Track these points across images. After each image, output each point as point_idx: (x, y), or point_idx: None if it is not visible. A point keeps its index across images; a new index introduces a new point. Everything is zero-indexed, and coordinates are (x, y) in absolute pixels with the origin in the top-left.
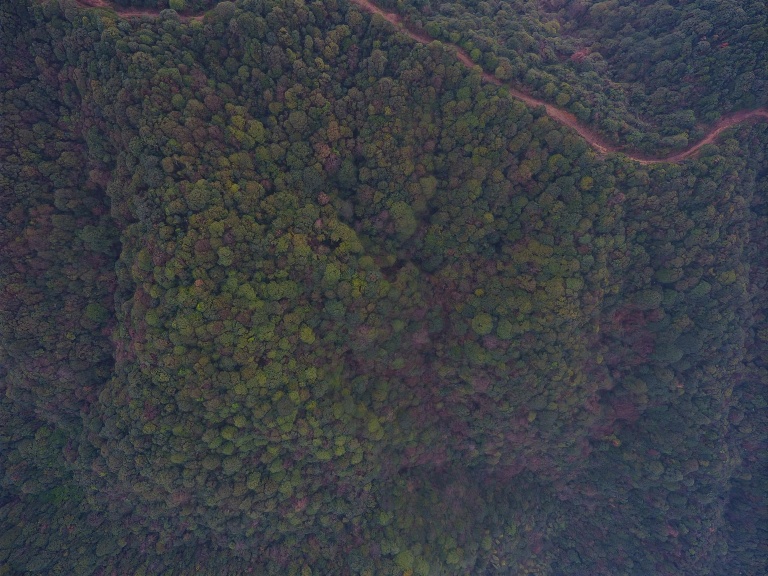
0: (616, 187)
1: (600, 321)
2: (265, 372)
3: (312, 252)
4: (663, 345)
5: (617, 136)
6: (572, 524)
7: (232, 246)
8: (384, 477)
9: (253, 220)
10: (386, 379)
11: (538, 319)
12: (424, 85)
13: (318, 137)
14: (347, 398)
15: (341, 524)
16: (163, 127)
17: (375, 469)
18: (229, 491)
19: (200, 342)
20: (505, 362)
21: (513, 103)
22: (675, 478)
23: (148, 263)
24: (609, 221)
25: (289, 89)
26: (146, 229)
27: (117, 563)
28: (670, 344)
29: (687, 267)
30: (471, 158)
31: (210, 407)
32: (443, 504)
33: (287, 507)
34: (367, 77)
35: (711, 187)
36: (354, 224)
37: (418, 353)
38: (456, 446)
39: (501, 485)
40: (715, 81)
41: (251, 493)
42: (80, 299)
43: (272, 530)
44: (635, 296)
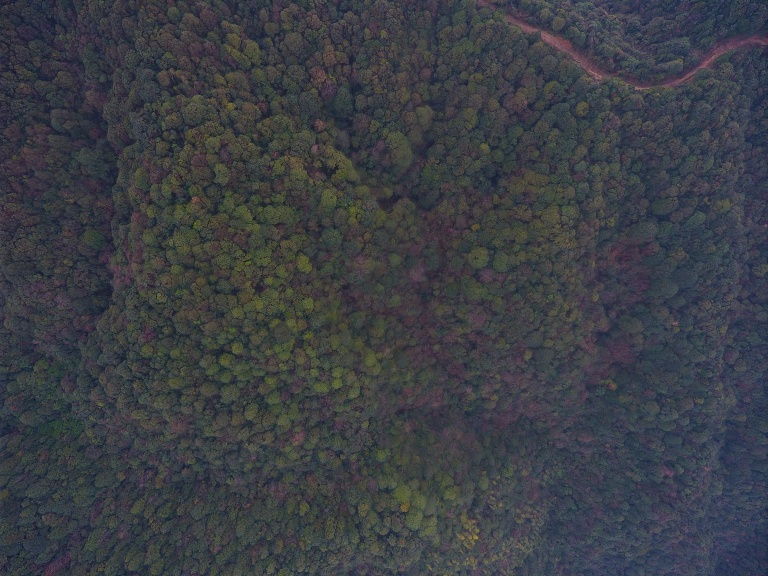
0: (611, 111)
1: (596, 256)
2: (262, 298)
3: (308, 177)
4: (658, 280)
5: (612, 62)
6: (569, 472)
7: (228, 164)
8: (381, 416)
9: (249, 140)
10: (383, 317)
11: (534, 248)
12: (420, 9)
13: (314, 61)
14: (344, 331)
15: (339, 460)
16: (159, 39)
17: (372, 405)
18: (227, 420)
19: (197, 262)
20: (501, 296)
21: (508, 27)
22: (670, 417)
23: (145, 181)
24: (604, 147)
25: (285, 9)
26: (143, 149)
27: (116, 496)
28: (665, 279)
29: (682, 197)
30: (467, 86)
31: (207, 330)
32: (440, 444)
33: (285, 441)
34: (363, 1)
35: (706, 109)
36: (350, 155)
37: (415, 293)
38: (453, 390)
39: (498, 431)
40: (710, 7)
41: (249, 424)
42: (77, 225)
43: (270, 466)
44: (630, 229)
